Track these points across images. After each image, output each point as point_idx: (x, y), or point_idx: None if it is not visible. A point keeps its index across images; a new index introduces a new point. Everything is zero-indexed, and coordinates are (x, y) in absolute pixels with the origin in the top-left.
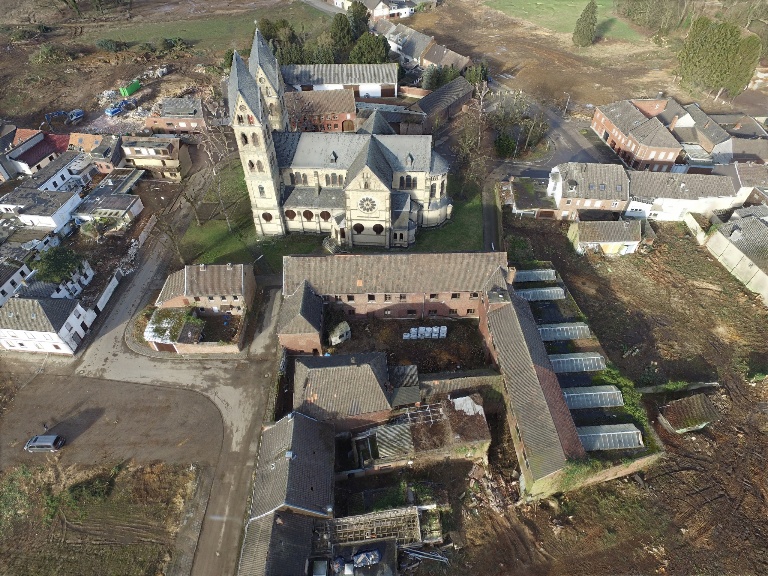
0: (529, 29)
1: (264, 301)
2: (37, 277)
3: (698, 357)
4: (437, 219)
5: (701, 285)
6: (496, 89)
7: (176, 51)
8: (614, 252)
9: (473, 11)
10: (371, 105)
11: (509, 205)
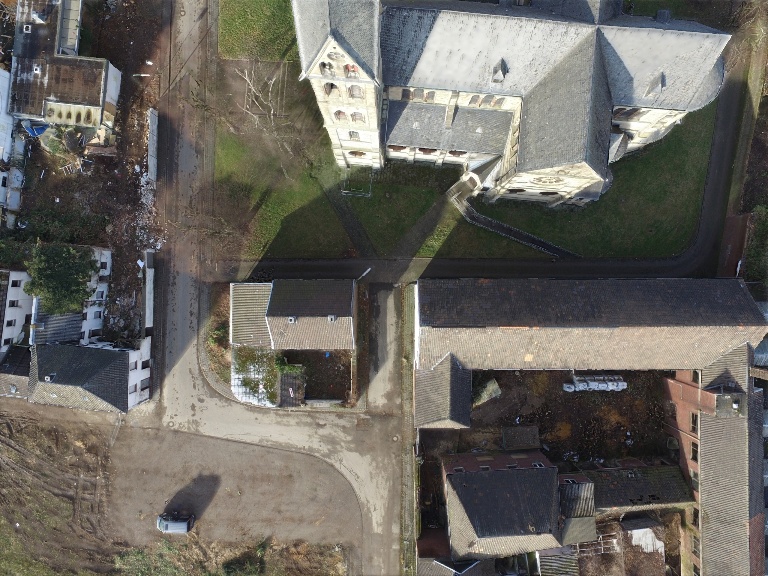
0: None
1: (372, 315)
2: (46, 311)
3: None
4: (643, 145)
5: None
6: None
7: None
8: None
9: None
10: None
11: None
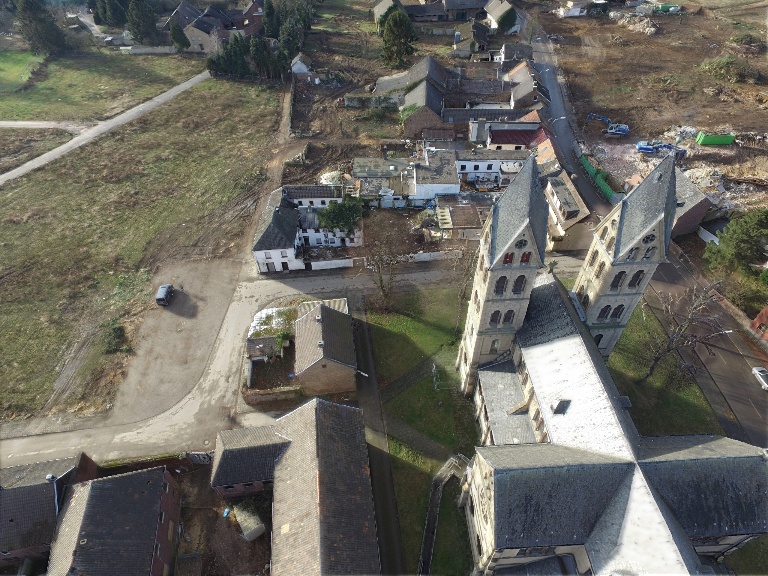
0: None
1: None
2: (320, 211)
3: None
4: None
5: None
6: None
7: None
8: None
9: None
10: None
11: None
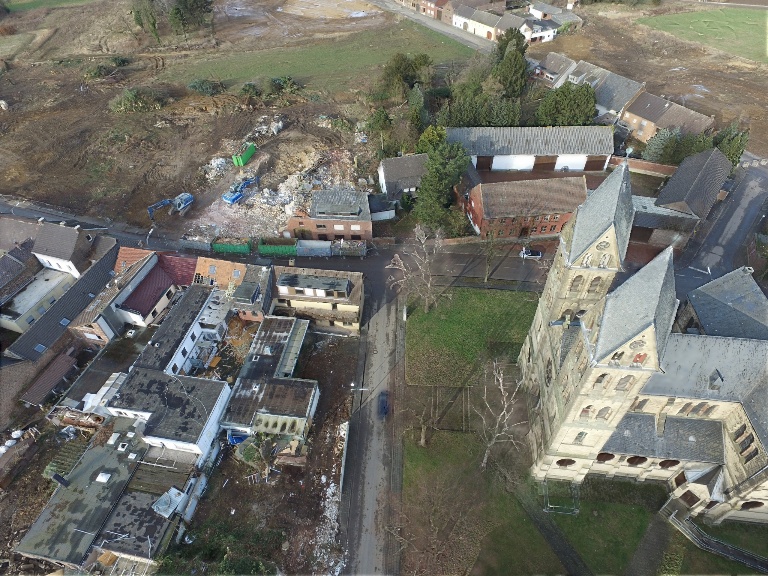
0: (720, 58)
1: None
2: None
3: None
4: None
5: None
6: None
7: (285, 94)
8: None
9: (632, 33)
10: None
11: None
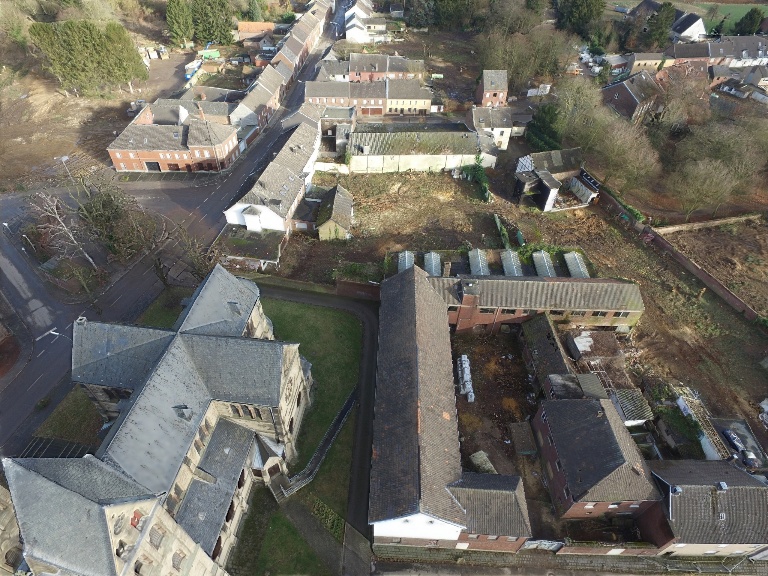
0: None
1: None
2: None
3: (468, 216)
4: (273, 336)
5: (395, 190)
6: None
7: None
8: (350, 219)
9: None
10: None
11: None
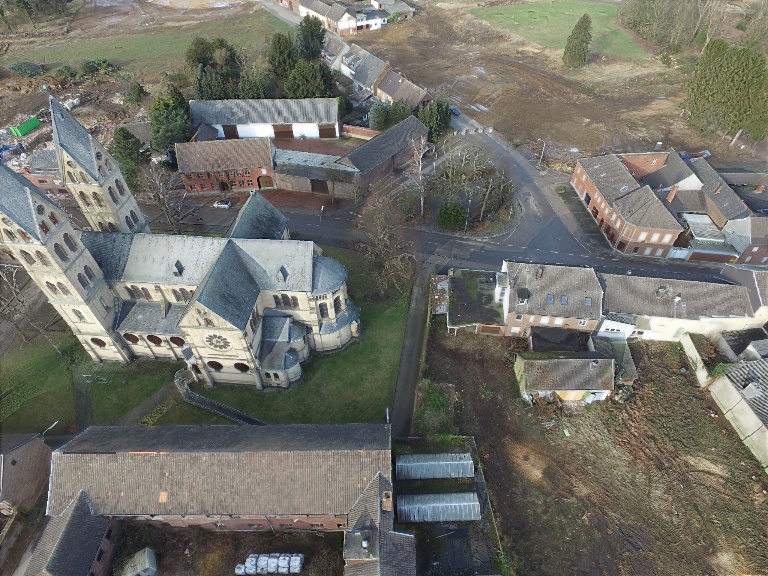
0: (515, 44)
1: None
2: None
3: None
4: (336, 341)
5: (698, 464)
6: (462, 126)
7: (100, 75)
8: (577, 399)
9: (454, 21)
10: (296, 155)
11: (442, 313)
